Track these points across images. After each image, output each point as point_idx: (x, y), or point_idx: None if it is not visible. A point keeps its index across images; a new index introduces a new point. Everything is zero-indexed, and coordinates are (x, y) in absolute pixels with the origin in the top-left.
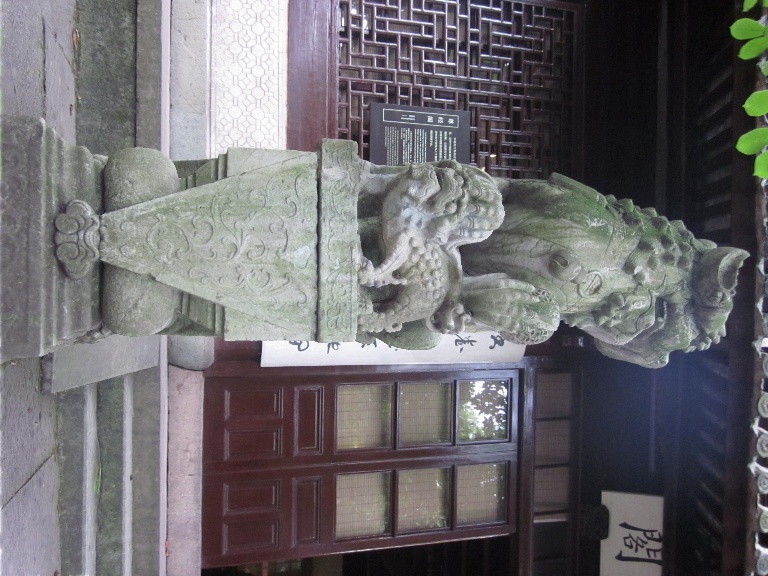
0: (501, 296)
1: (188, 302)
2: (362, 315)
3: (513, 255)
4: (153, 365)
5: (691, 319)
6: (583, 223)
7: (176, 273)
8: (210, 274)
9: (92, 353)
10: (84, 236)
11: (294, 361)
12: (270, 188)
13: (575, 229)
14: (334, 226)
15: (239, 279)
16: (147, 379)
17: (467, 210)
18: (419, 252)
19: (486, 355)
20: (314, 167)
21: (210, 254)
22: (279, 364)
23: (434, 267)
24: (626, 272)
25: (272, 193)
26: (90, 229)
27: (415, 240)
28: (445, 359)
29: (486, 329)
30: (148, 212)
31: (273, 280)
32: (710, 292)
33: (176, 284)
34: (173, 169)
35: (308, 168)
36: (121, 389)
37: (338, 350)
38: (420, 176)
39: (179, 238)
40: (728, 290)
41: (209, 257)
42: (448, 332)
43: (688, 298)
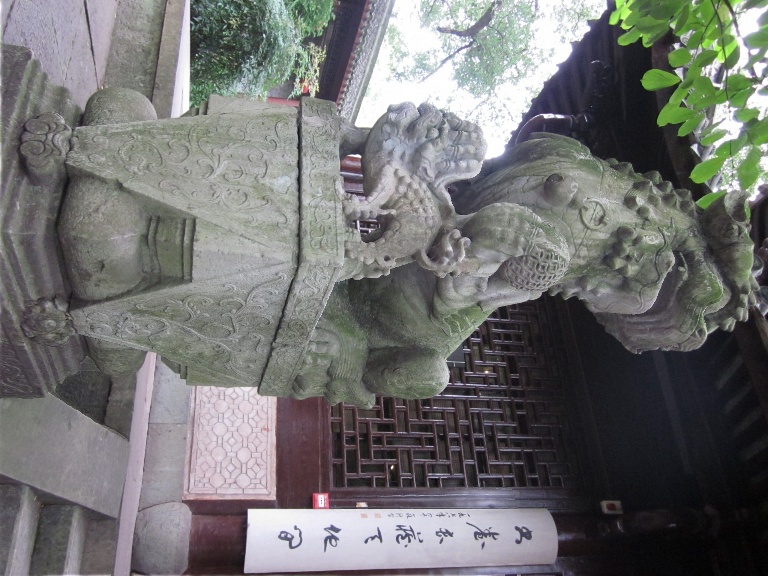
0: (498, 209)
1: (156, 226)
2: (349, 241)
3: (506, 197)
4: (112, 514)
5: (715, 268)
6: (570, 156)
7: (146, 183)
8: (182, 187)
9: (40, 448)
10: (53, 137)
11: (284, 564)
12: (250, 128)
13: (563, 163)
14: (315, 161)
15: (214, 195)
16: (102, 536)
17: (450, 137)
18: (405, 180)
19: (513, 552)
20: (294, 117)
21: (184, 172)
22: (266, 569)
23: (423, 197)
24: (628, 207)
25: (252, 131)
26: (60, 133)
27: (400, 170)
28: (465, 559)
29: (489, 262)
30: (123, 131)
31: (251, 200)
32: (724, 228)
33: (144, 192)
34: (154, 113)
35: (288, 117)
36: (68, 525)
37: (337, 547)
38: (399, 106)
39: (153, 155)
40: (742, 222)
41: (183, 173)
42: (447, 263)
43: (704, 246)
